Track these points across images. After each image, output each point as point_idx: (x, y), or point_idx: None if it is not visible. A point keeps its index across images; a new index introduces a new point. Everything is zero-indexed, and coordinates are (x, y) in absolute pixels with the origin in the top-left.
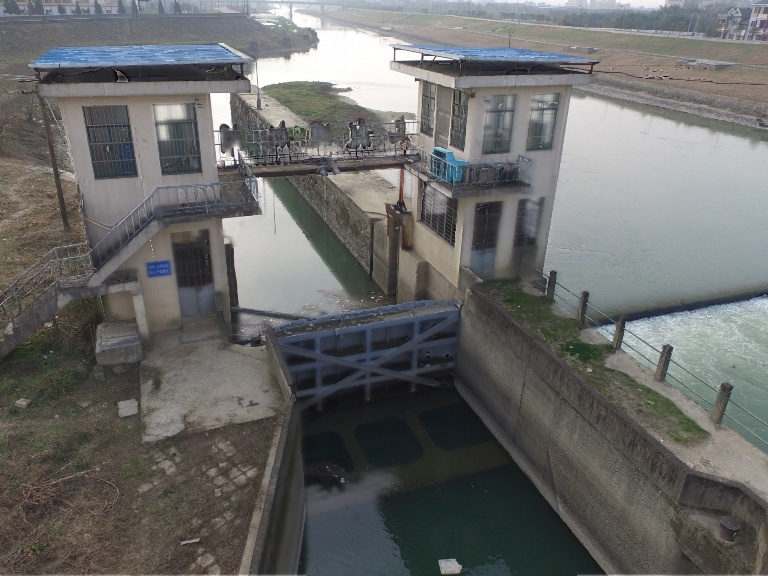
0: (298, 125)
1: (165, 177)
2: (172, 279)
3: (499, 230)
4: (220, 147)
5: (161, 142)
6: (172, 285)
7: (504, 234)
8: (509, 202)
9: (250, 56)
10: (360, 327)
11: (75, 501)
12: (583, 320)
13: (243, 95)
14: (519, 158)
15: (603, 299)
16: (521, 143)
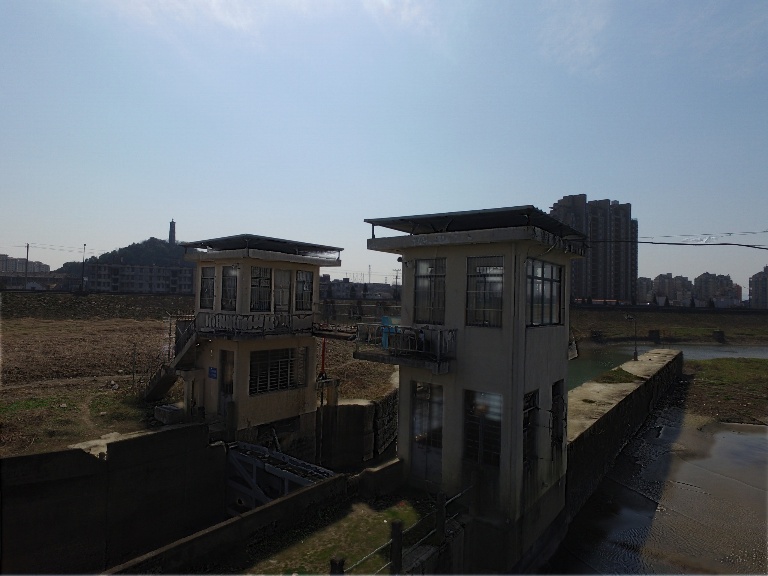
0: (639, 372)
1: (222, 311)
2: None
3: (442, 425)
4: (322, 316)
5: (223, 289)
6: (216, 387)
7: (447, 432)
8: (450, 389)
9: (630, 314)
10: (281, 472)
11: (6, 447)
12: (393, 572)
13: (648, 353)
14: (455, 333)
15: None
16: (458, 315)
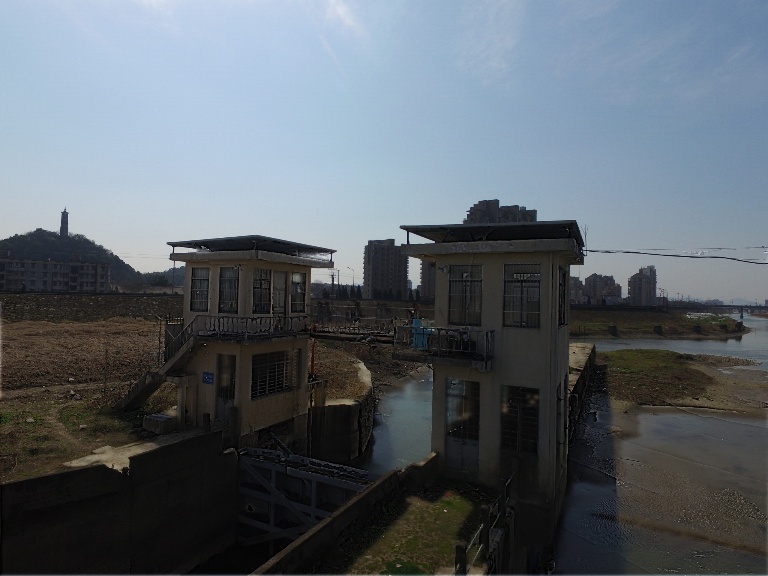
0: (572, 364)
1: (220, 314)
2: (213, 388)
3: (479, 418)
4: (316, 317)
5: (221, 291)
6: (213, 392)
7: (485, 425)
8: (487, 385)
9: None
10: (307, 474)
11: None
12: (484, 554)
13: None
14: (492, 333)
15: None
16: (495, 317)
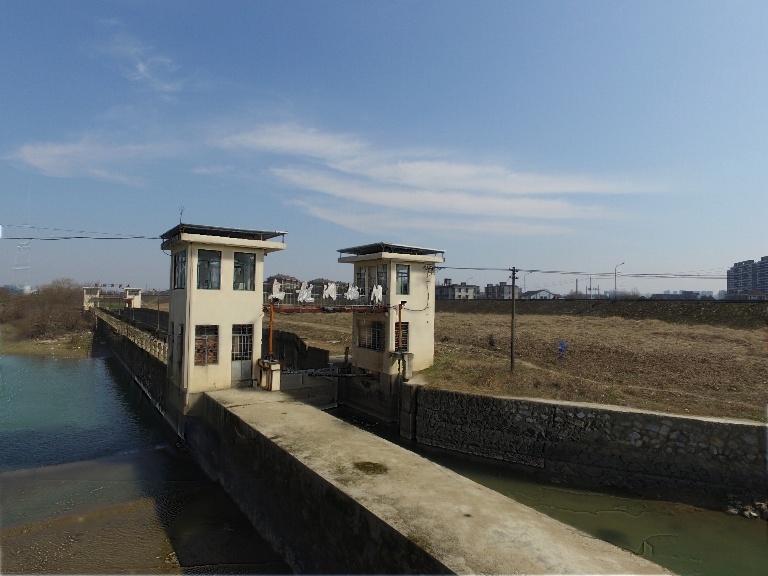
0: None
1: None
2: None
3: None
4: (381, 298)
5: None
6: None
7: None
8: None
9: None
10: None
11: None
12: None
13: None
14: None
15: (20, 482)
16: None
